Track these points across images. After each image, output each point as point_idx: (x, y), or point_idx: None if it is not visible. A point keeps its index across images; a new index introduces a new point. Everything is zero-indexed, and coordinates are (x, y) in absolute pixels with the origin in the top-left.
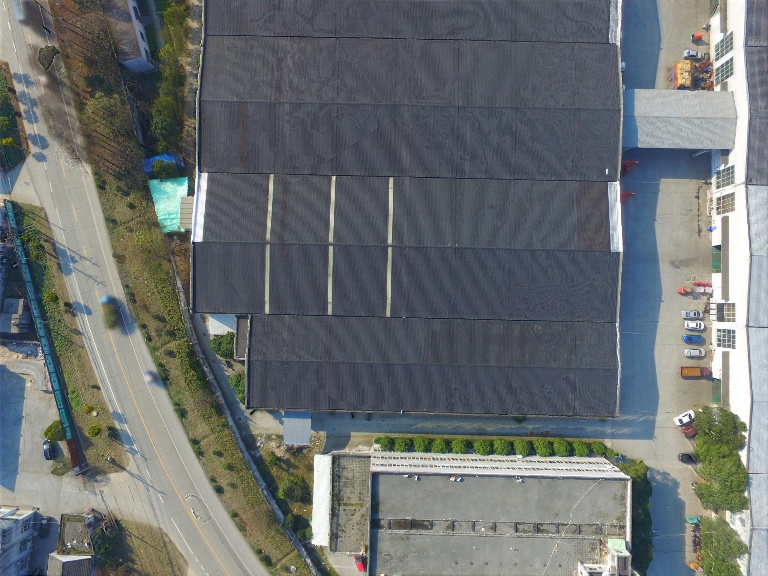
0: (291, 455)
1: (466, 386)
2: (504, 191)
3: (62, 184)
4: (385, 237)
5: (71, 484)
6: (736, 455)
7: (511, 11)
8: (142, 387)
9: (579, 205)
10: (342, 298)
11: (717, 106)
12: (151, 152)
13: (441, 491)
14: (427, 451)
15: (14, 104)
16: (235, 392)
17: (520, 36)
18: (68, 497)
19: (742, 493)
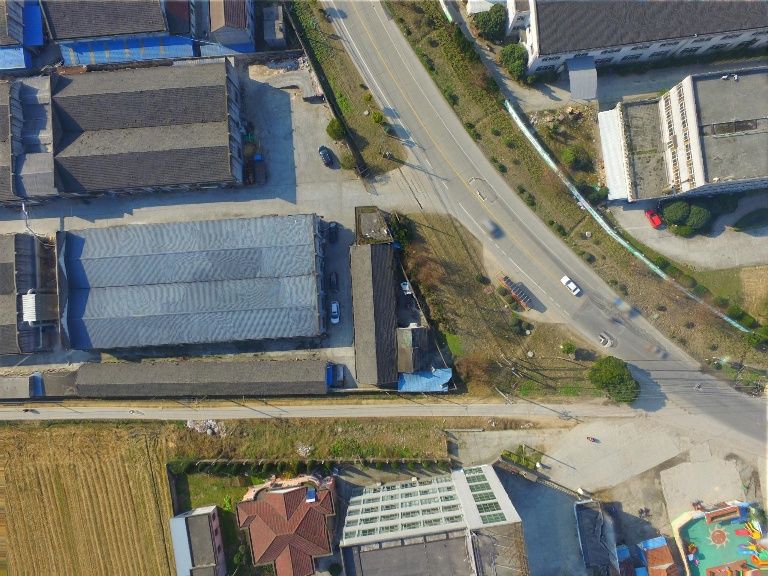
0: (567, 127)
1: None
2: None
3: None
4: None
5: (351, 188)
6: None
7: None
8: (409, 81)
9: None
10: None
11: None
12: None
13: (761, 89)
14: None
15: None
16: (500, 75)
17: None
18: (350, 201)
19: None
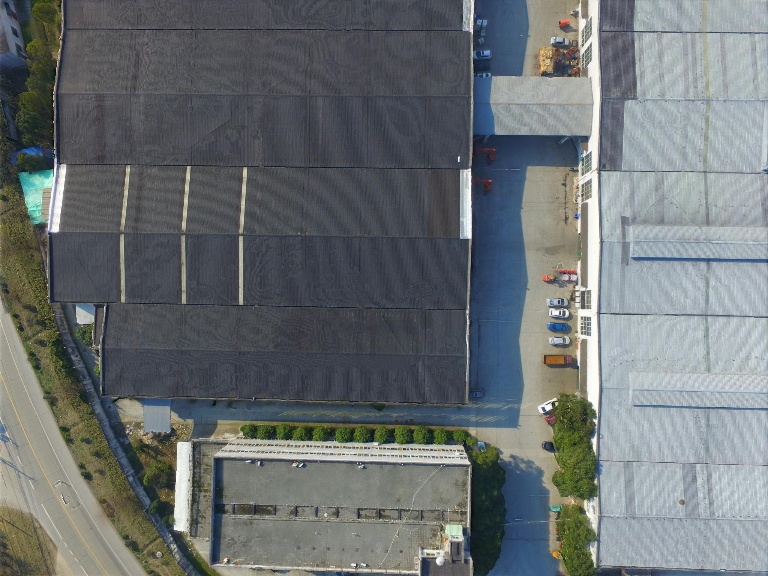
0: (159, 442)
1: (312, 373)
2: (356, 179)
3: None
4: (237, 226)
5: None
6: (587, 442)
7: (364, 0)
8: (14, 376)
9: (430, 193)
10: (196, 287)
11: (574, 92)
12: (22, 145)
13: (284, 477)
14: (287, 438)
15: None
16: None
17: (374, 25)
18: None
19: (591, 480)
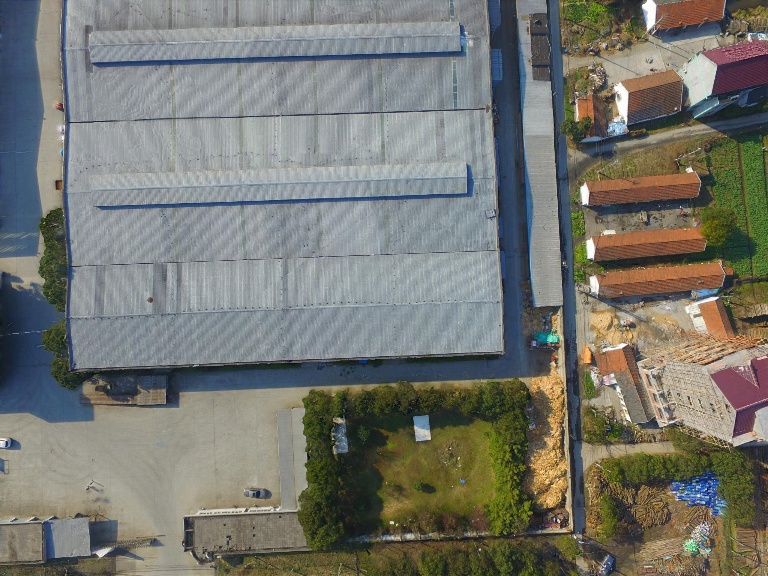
0: None
1: None
2: None
3: None
4: None
5: None
6: (59, 249)
7: None
8: None
9: None
10: None
11: None
12: None
13: None
14: None
15: None
16: None
17: None
18: None
19: (61, 285)
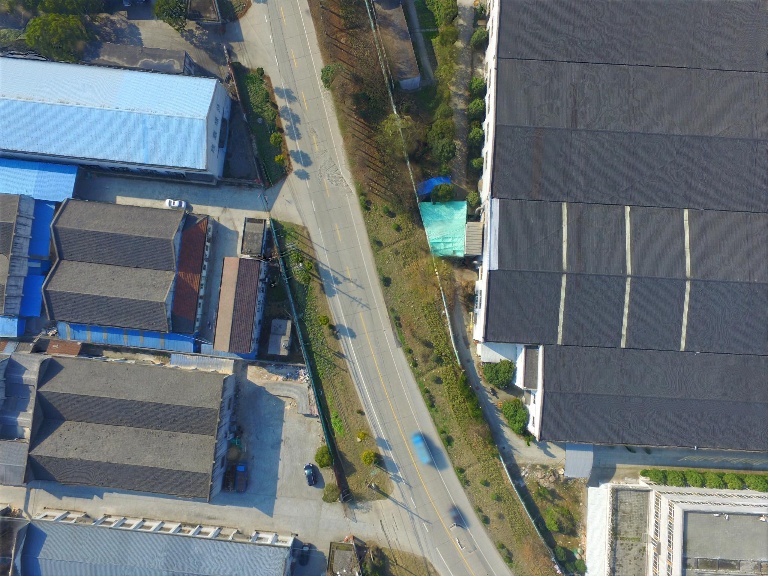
0: (556, 486)
1: None
2: None
3: (325, 203)
4: (683, 270)
5: (331, 510)
6: None
7: None
8: (407, 413)
9: None
10: (636, 331)
11: None
12: (422, 174)
13: (750, 531)
14: (703, 486)
15: (276, 119)
16: (499, 420)
17: None
18: (328, 524)
19: None
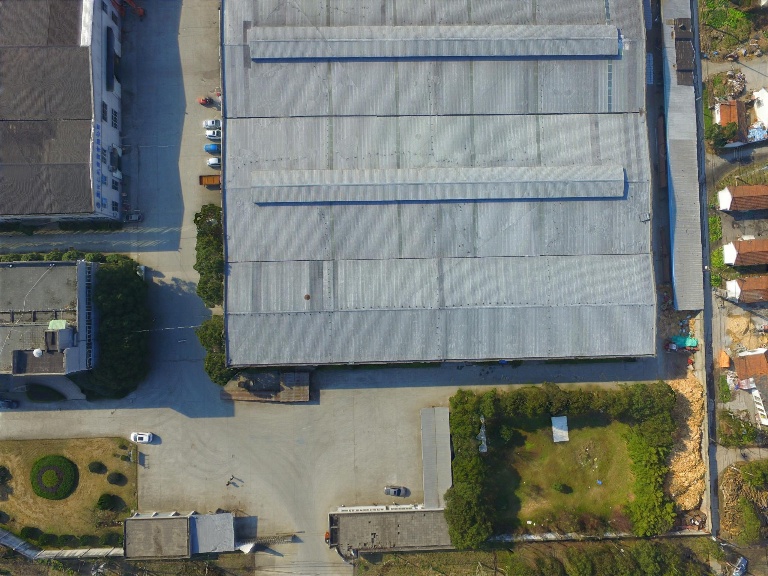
0: None
1: None
2: None
3: None
4: None
5: None
6: (215, 245)
7: None
8: None
9: (53, 3)
10: None
11: None
12: None
13: None
14: None
15: None
16: None
17: None
18: None
19: (218, 281)
